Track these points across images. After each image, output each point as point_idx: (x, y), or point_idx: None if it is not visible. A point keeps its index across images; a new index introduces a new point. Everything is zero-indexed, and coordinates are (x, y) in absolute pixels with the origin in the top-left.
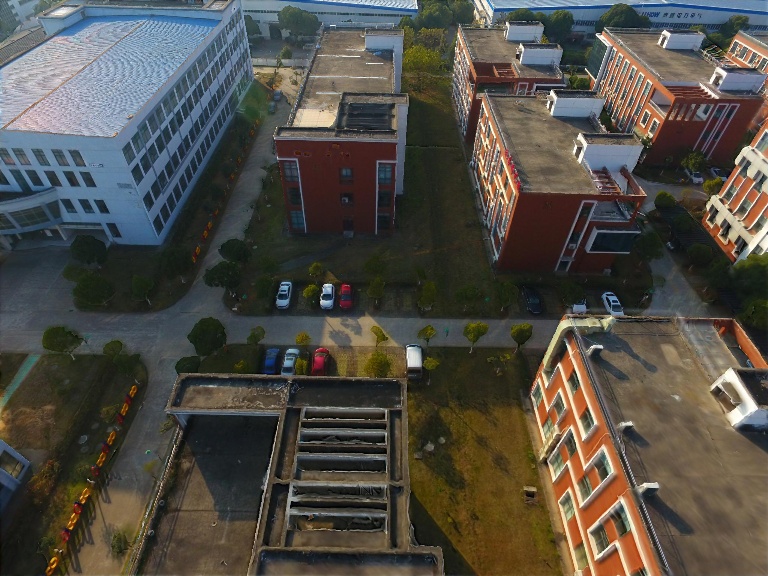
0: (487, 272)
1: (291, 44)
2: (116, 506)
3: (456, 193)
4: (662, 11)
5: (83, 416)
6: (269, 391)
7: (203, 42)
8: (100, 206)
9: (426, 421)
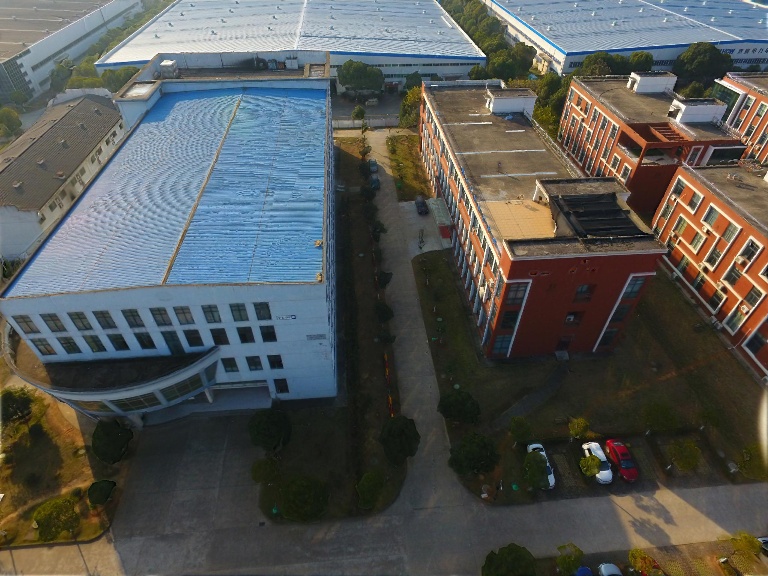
0: (767, 400)
1: (350, 100)
2: None
3: (653, 283)
4: (737, 47)
5: None
6: None
7: None
8: (273, 361)
9: None
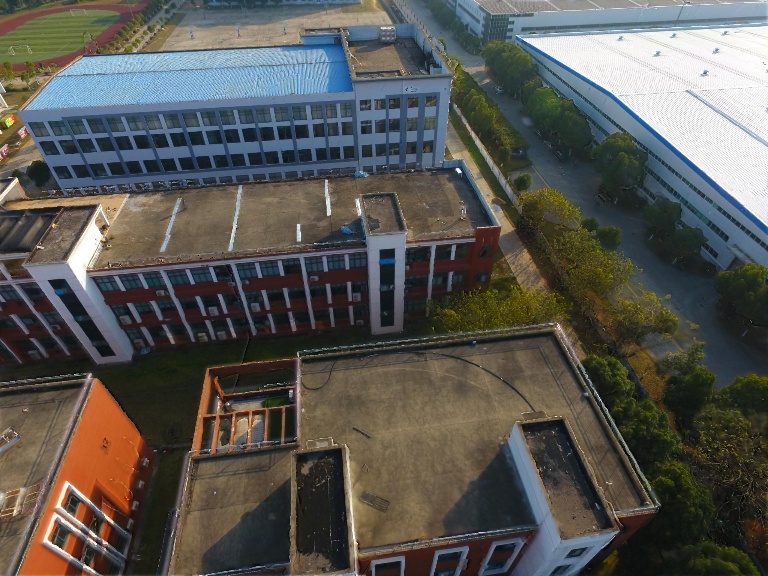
0: None
1: None
2: None
3: None
4: None
5: None
6: None
7: (269, 97)
8: None
9: None
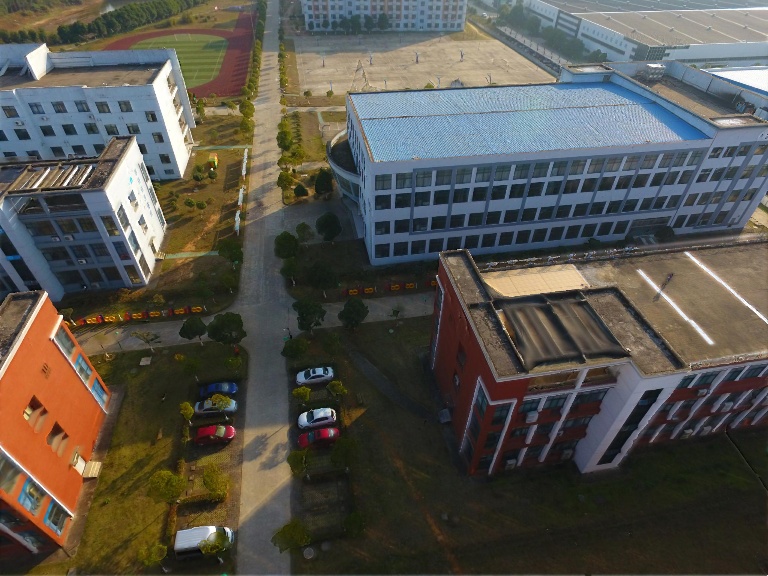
0: None
1: None
2: (100, 339)
3: (638, 575)
4: None
5: (174, 292)
6: (0, 348)
7: (629, 145)
8: None
9: (110, 575)
